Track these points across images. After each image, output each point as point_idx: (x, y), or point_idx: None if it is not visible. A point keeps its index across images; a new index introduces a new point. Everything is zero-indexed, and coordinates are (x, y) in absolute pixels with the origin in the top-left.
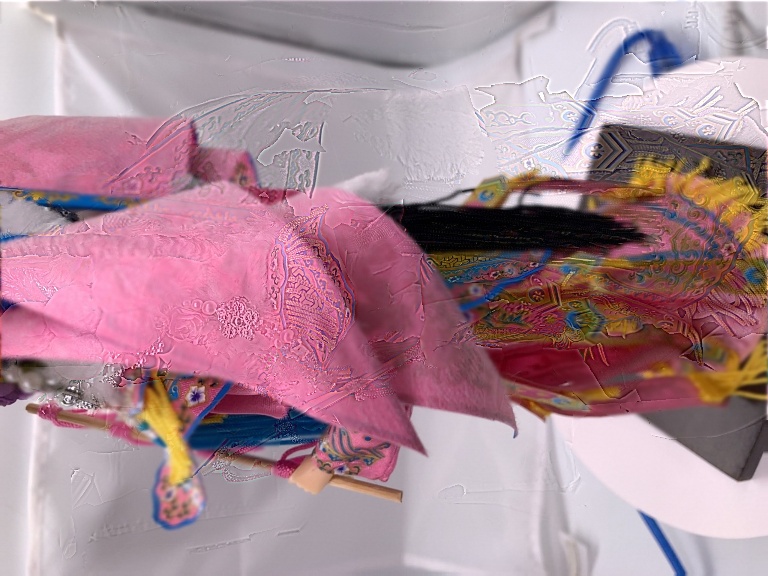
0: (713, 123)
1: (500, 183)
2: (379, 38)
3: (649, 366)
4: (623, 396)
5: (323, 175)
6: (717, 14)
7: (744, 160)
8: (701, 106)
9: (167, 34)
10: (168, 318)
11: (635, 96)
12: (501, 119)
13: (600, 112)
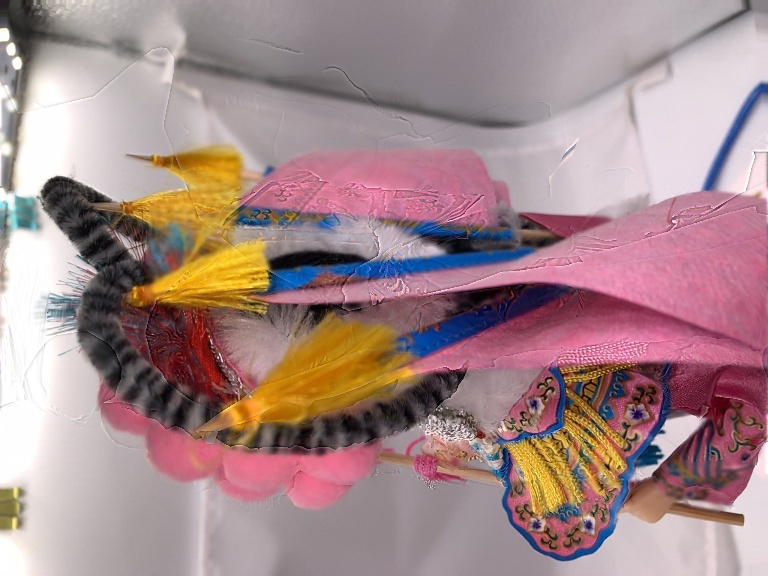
0: None
1: None
2: None
3: None
4: None
5: None
6: None
7: None
8: None
9: None
10: None
11: None
12: None
13: None
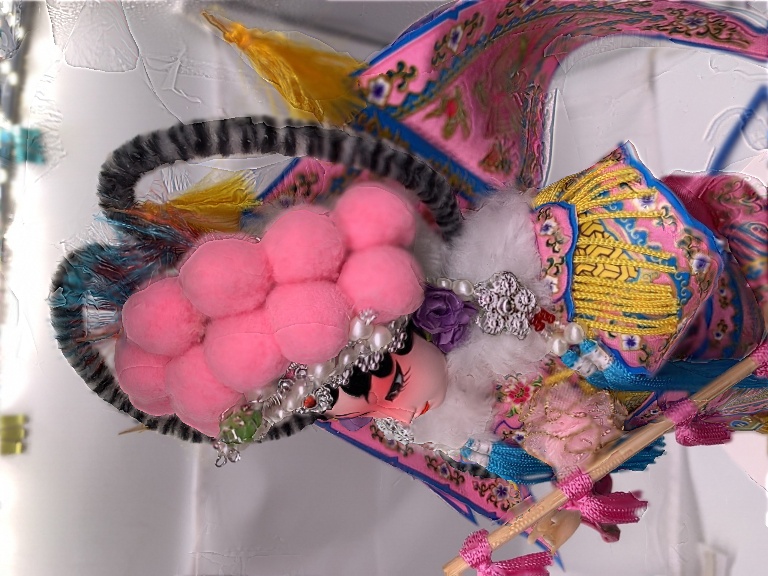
0: None
1: None
2: None
3: None
4: None
5: (558, 154)
6: None
7: None
8: None
9: None
10: None
11: None
12: None
13: None
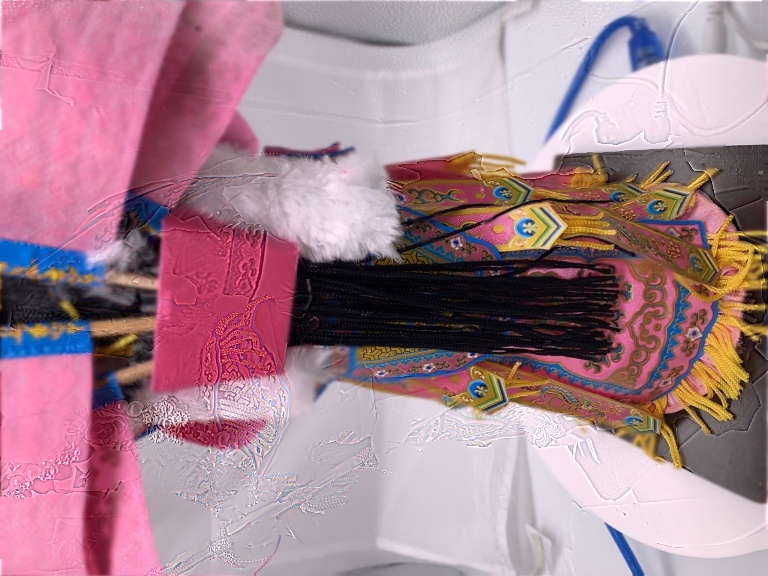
0: (665, 198)
1: (423, 264)
2: (353, 132)
3: (642, 463)
4: (618, 497)
5: (270, 264)
6: (685, 103)
7: (700, 236)
8: (652, 182)
9: (142, 132)
10: (85, 422)
11: (583, 174)
12: (425, 196)
13: (537, 188)
